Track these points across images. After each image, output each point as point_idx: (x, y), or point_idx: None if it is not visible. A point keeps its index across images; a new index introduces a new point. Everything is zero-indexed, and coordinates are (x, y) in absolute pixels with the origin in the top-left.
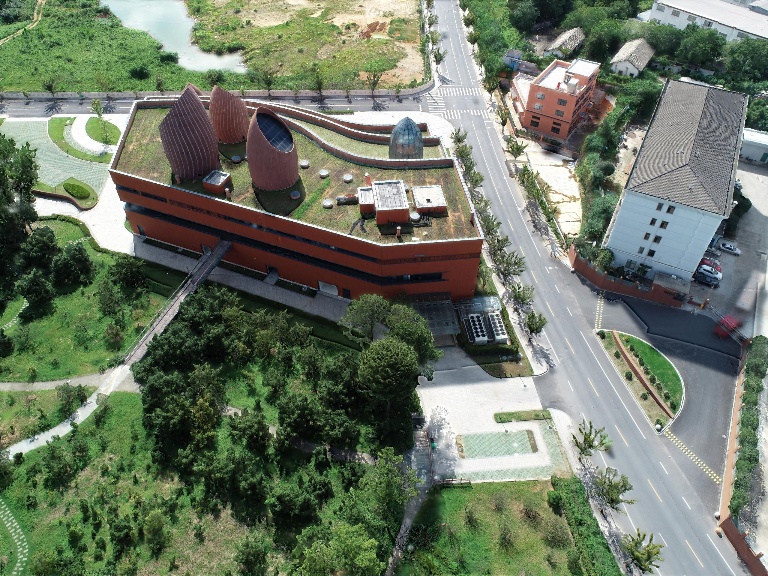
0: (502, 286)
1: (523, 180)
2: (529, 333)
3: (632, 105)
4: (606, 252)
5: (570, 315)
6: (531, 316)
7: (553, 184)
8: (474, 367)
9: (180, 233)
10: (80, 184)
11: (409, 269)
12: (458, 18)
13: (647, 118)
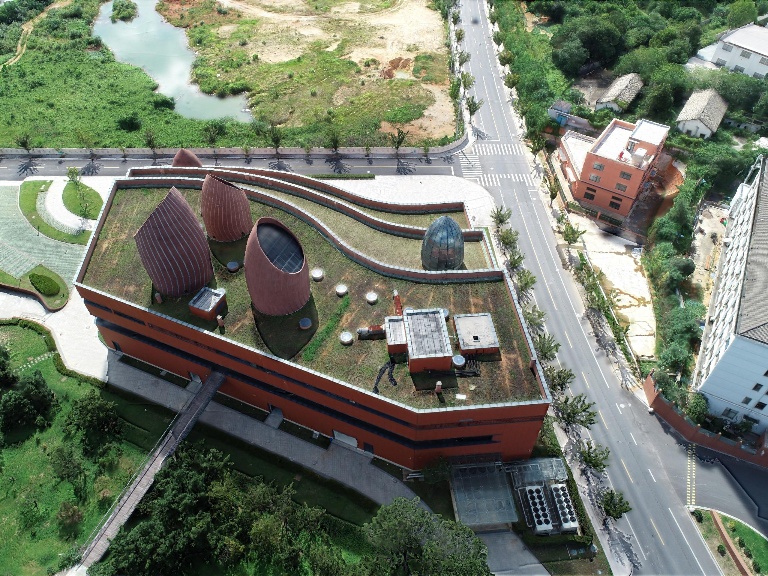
0: (564, 433)
1: (583, 280)
2: (603, 510)
3: (707, 177)
4: (699, 399)
5: (653, 481)
6: (609, 498)
7: (616, 280)
8: (535, 567)
9: (163, 356)
10: (49, 274)
11: (451, 433)
12: (491, 53)
13: (724, 191)
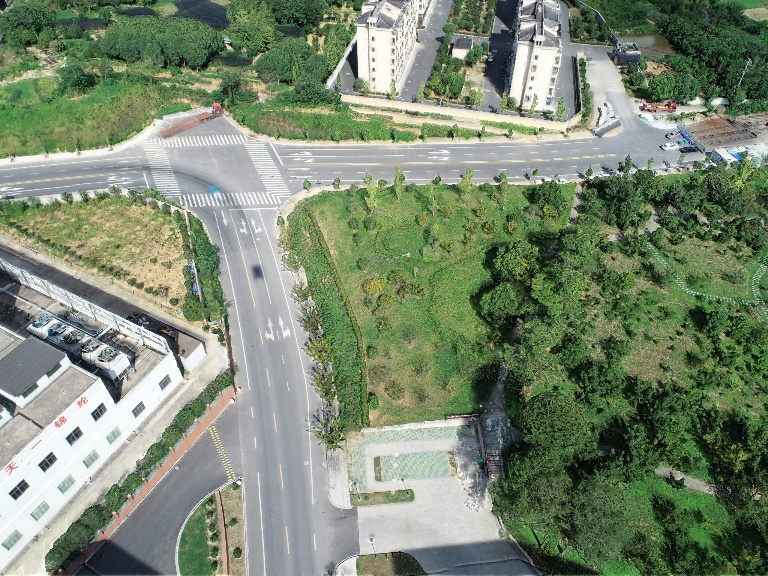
0: None
1: None
2: None
3: None
4: None
5: None
6: None
7: None
8: (432, 570)
9: None
10: None
11: None
12: None
13: None
